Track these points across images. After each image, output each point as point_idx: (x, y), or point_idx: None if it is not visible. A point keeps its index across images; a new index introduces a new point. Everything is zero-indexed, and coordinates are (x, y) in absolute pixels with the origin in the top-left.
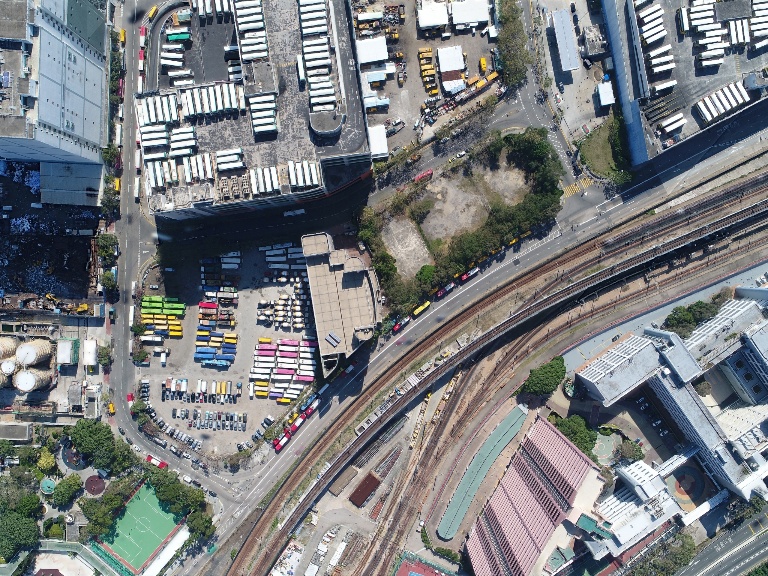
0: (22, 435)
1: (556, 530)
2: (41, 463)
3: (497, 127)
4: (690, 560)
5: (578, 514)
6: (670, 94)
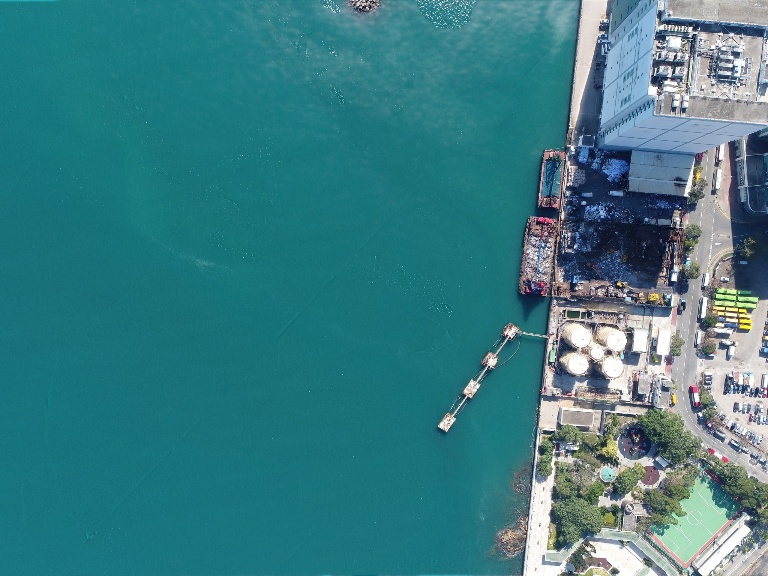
0: (588, 422)
1: None
2: (608, 451)
3: None
4: None
5: None
6: None
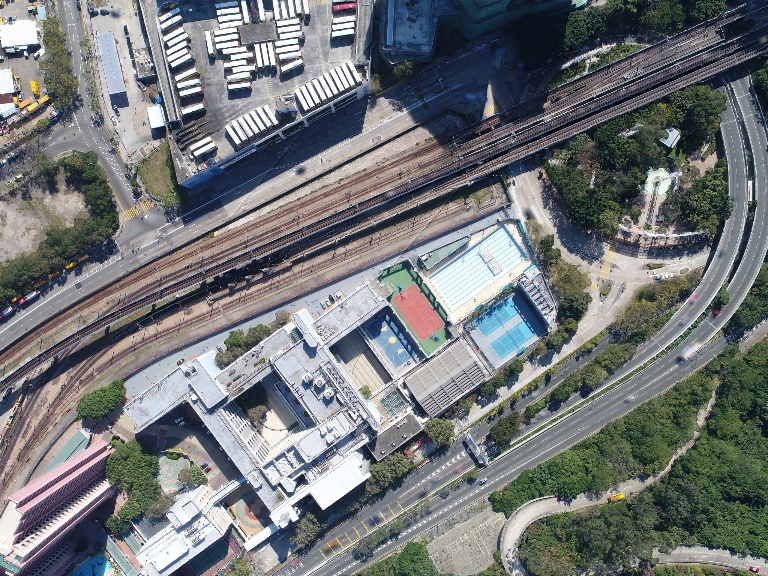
0: None
1: None
2: None
3: (54, 150)
4: None
5: None
6: (202, 117)
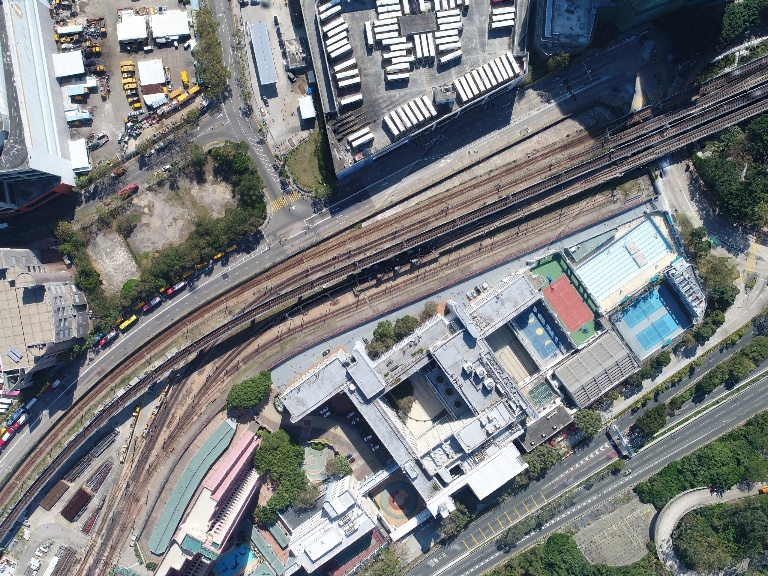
0: None
1: (171, 550)
2: None
3: (202, 141)
4: (402, 575)
5: (183, 535)
6: (359, 108)
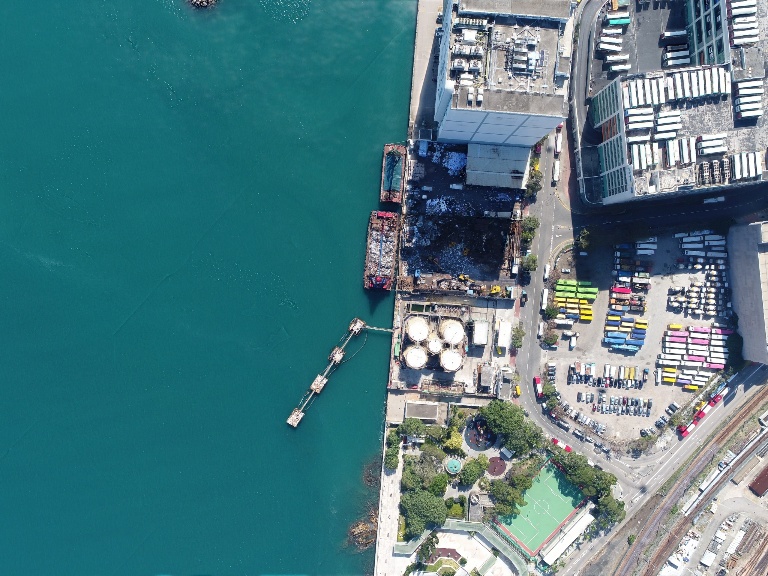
0: (432, 414)
1: None
2: (452, 443)
3: None
4: None
5: None
6: None
